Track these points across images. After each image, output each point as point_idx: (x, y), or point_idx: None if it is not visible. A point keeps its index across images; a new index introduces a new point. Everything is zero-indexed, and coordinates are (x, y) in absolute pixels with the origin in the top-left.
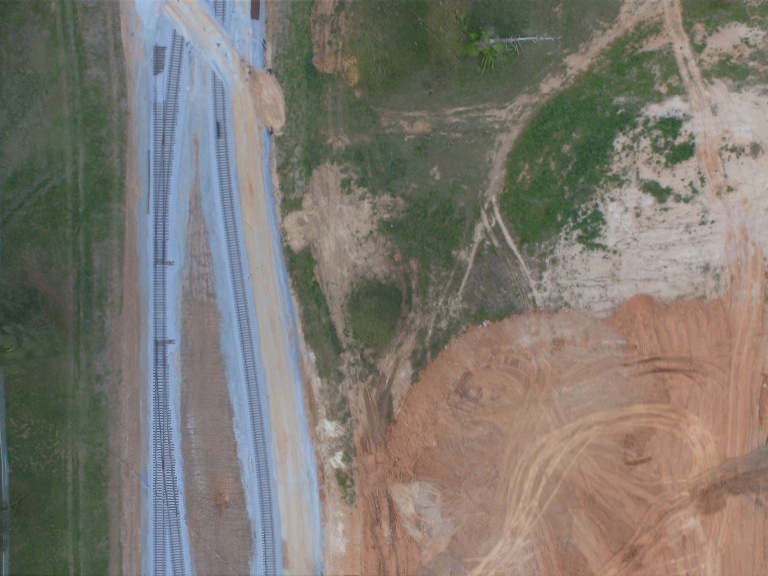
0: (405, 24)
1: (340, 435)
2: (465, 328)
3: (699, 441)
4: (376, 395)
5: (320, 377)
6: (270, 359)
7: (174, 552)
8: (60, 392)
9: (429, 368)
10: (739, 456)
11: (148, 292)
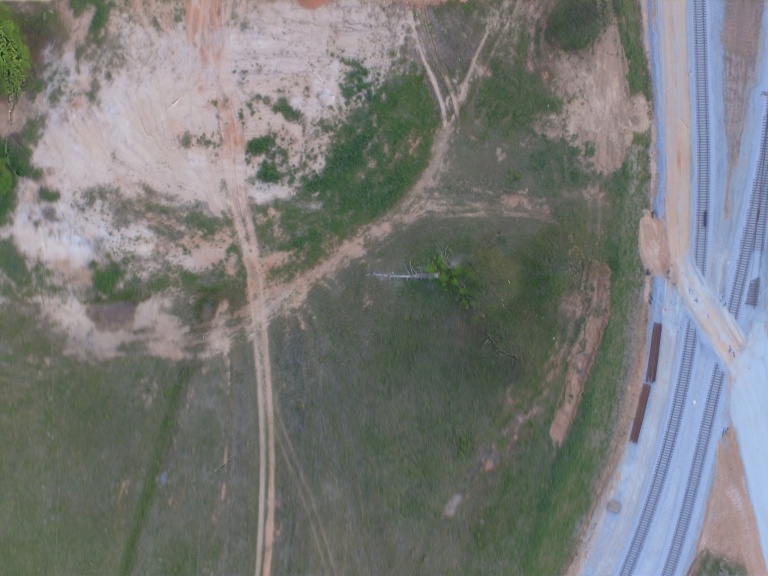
0: (518, 302)
1: None
2: None
3: None
4: None
5: None
6: None
7: None
8: None
9: None
10: None
11: None
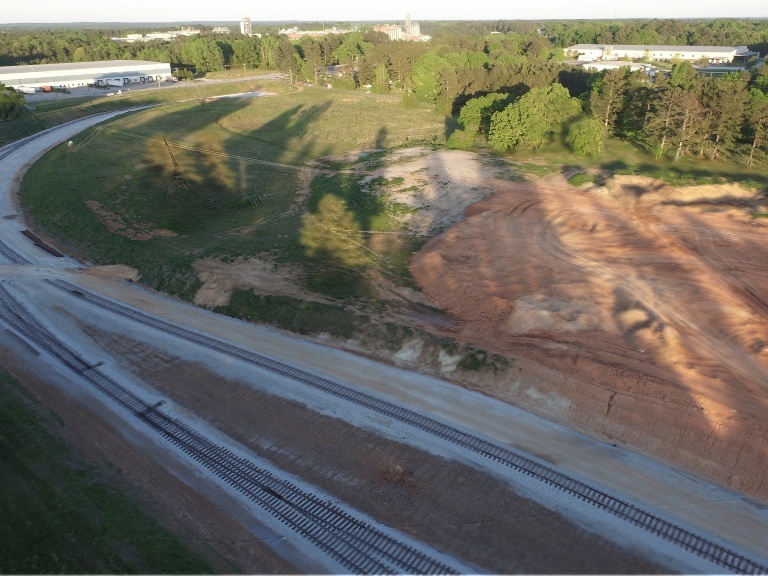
0: None
1: (422, 346)
2: (407, 261)
3: (595, 211)
4: (407, 309)
5: (349, 337)
6: (287, 355)
7: (420, 571)
8: (20, 518)
9: (418, 281)
10: (619, 205)
11: (89, 394)
